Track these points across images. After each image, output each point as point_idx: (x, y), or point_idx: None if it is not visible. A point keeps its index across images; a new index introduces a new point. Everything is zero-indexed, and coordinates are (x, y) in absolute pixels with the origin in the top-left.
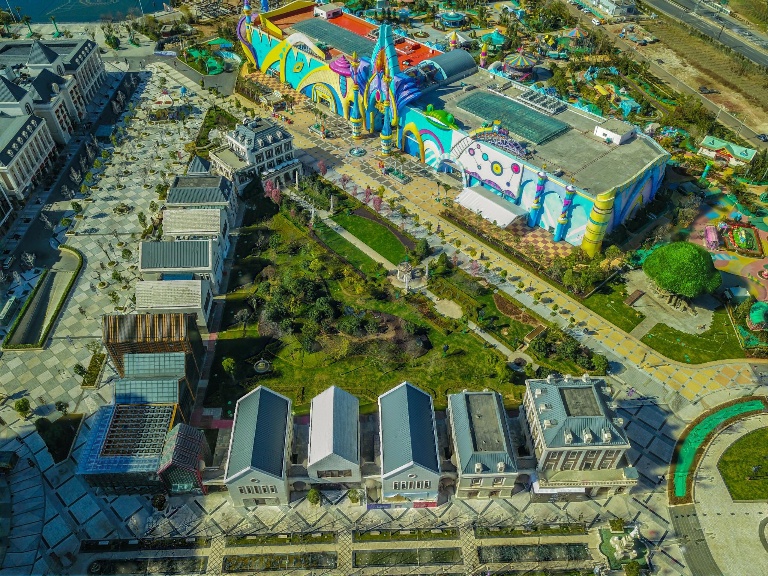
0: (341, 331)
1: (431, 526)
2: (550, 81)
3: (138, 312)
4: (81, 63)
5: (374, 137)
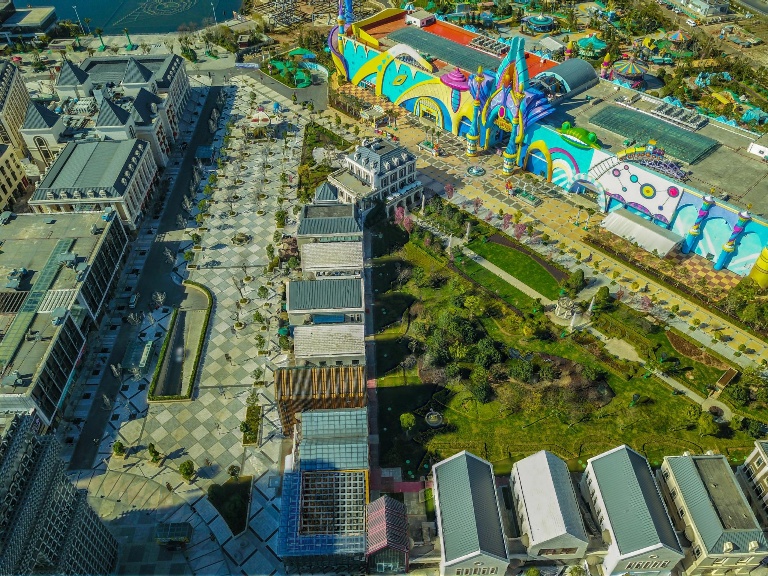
0: (513, 377)
1: None
2: (666, 90)
3: (296, 360)
4: (172, 80)
5: (490, 154)
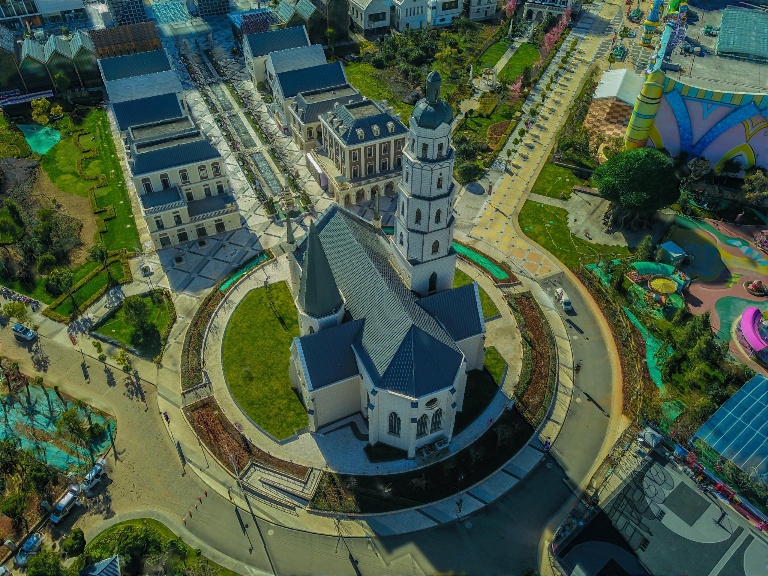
0: None
1: (267, 134)
2: None
3: None
4: None
5: None
